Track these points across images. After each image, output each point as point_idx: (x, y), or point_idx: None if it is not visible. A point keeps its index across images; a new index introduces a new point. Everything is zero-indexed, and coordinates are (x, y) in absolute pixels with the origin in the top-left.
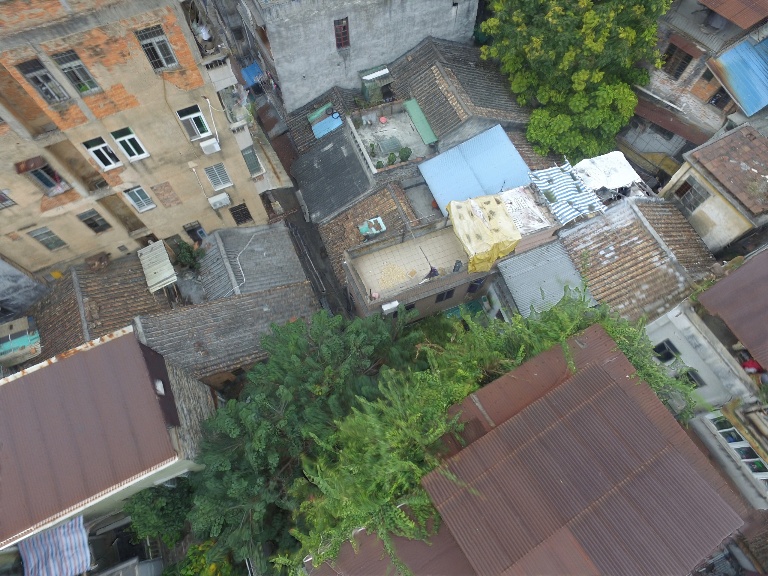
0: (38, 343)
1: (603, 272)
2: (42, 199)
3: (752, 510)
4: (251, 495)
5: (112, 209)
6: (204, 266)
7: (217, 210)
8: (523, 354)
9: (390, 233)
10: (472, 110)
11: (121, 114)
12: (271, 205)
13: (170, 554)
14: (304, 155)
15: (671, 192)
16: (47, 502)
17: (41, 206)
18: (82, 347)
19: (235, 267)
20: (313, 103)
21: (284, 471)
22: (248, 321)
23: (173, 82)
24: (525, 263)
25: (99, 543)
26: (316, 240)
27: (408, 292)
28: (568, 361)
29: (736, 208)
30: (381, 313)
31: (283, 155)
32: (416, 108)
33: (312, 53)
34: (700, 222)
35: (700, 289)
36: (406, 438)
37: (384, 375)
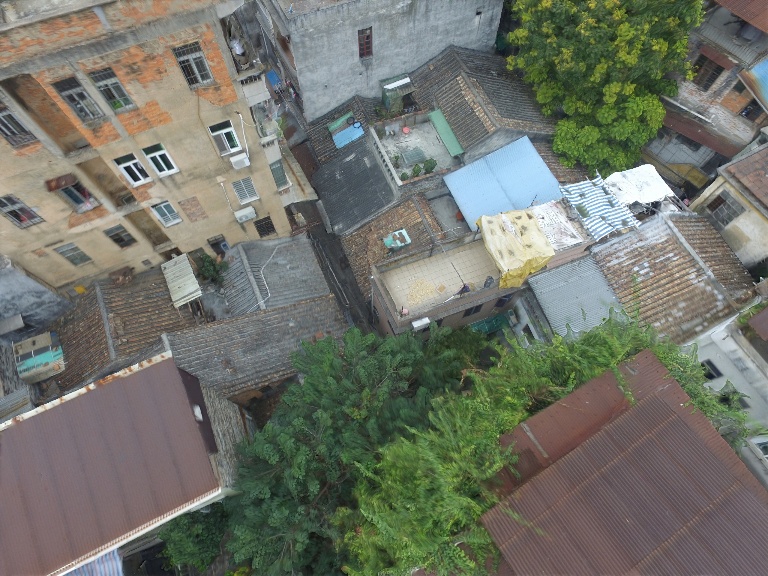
0: (61, 359)
1: (638, 289)
2: (70, 216)
3: None
4: (291, 523)
5: (137, 223)
6: (227, 279)
7: (242, 223)
8: (574, 381)
9: (415, 246)
10: (499, 122)
11: (154, 130)
12: (294, 217)
13: None
14: (325, 165)
15: (703, 206)
16: (88, 535)
17: (69, 222)
18: (121, 373)
19: (259, 281)
20: (333, 112)
21: (321, 496)
22: (274, 337)
23: (207, 98)
24: (556, 279)
25: (126, 565)
26: (335, 250)
27: (438, 308)
28: (625, 391)
29: None
30: (411, 330)
31: (303, 165)
32: (441, 119)
33: (335, 63)
34: (733, 237)
35: (748, 311)
36: (461, 472)
37: (433, 404)
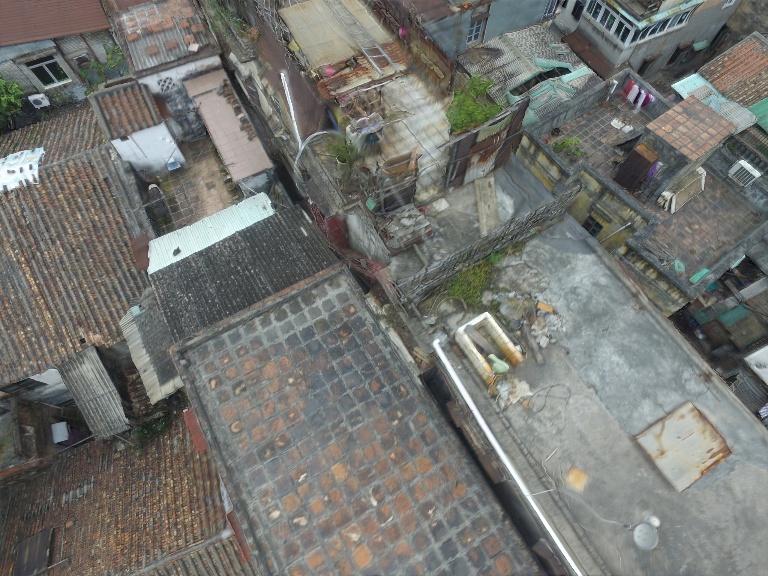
0: None
1: None
2: None
3: (613, 67)
4: None
5: None
6: None
7: None
8: None
9: None
10: None
11: None
12: None
13: None
14: None
15: None
16: None
17: None
18: None
19: None
20: None
21: None
22: None
23: None
24: None
25: None
26: None
27: None
28: None
29: None
30: None
31: None
32: None
33: None
34: None
35: None
36: None
37: None
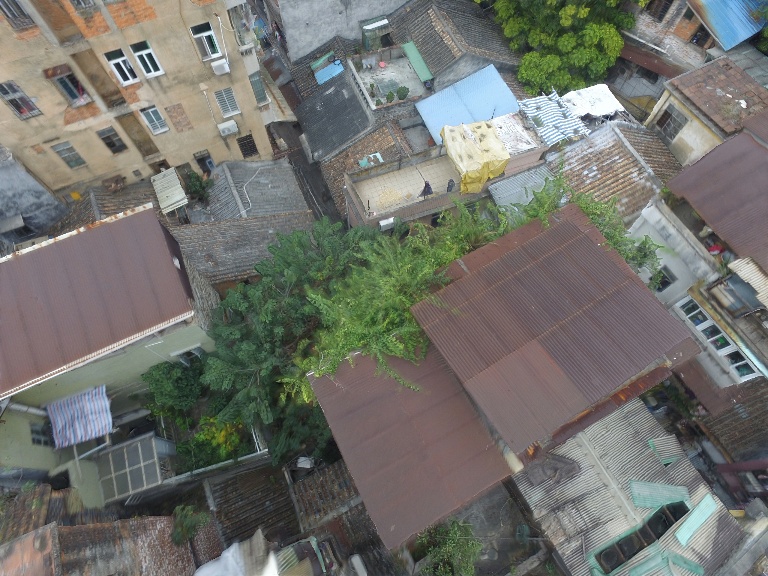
0: None
1: (586, 190)
2: (66, 111)
3: (718, 389)
4: (259, 361)
5: (128, 132)
6: (213, 195)
7: (225, 139)
8: (505, 225)
9: None
10: (466, 48)
11: (140, 26)
12: (276, 142)
13: (182, 440)
14: (307, 99)
15: (653, 123)
16: (78, 346)
17: (64, 118)
18: (107, 219)
19: (242, 195)
20: (316, 52)
21: None
22: (254, 240)
23: None
24: (514, 185)
25: (116, 435)
26: (318, 185)
27: (404, 210)
28: None
29: (711, 129)
30: (379, 230)
31: None
32: (413, 49)
33: None
34: (680, 149)
35: None
36: (398, 283)
37: (379, 239)
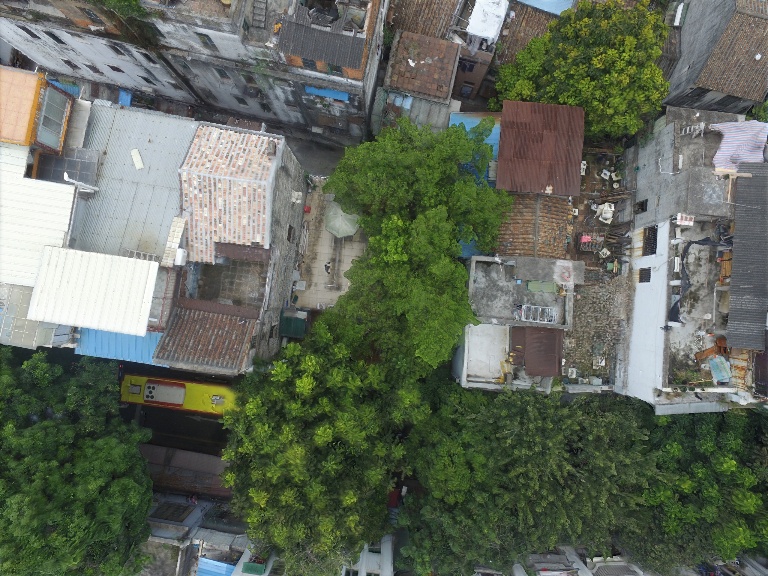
0: None
1: None
2: None
3: None
4: None
5: None
6: None
7: None
8: None
9: None
10: None
11: None
12: None
13: None
14: None
15: None
16: None
17: None
18: None
19: None
20: None
21: None
22: None
23: None
24: None
25: None
26: None
27: None
28: None
29: None
30: None
31: None
32: None
33: None
34: None
35: None
36: None
37: None
